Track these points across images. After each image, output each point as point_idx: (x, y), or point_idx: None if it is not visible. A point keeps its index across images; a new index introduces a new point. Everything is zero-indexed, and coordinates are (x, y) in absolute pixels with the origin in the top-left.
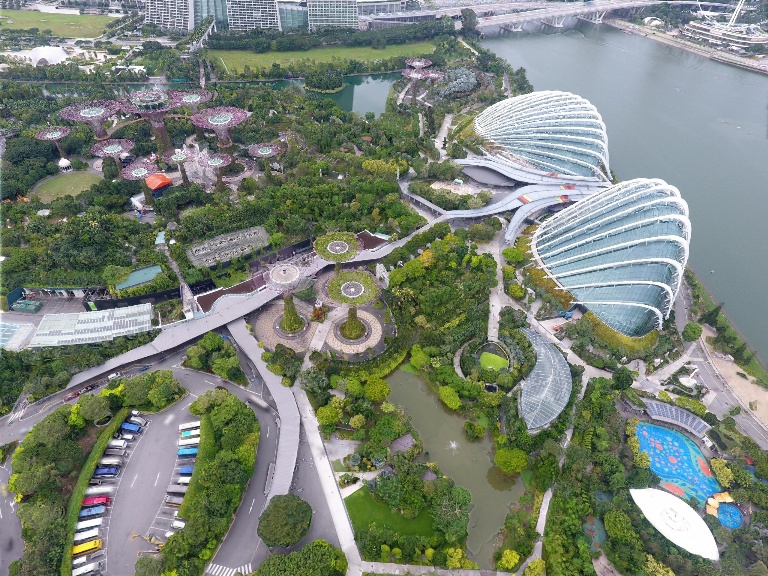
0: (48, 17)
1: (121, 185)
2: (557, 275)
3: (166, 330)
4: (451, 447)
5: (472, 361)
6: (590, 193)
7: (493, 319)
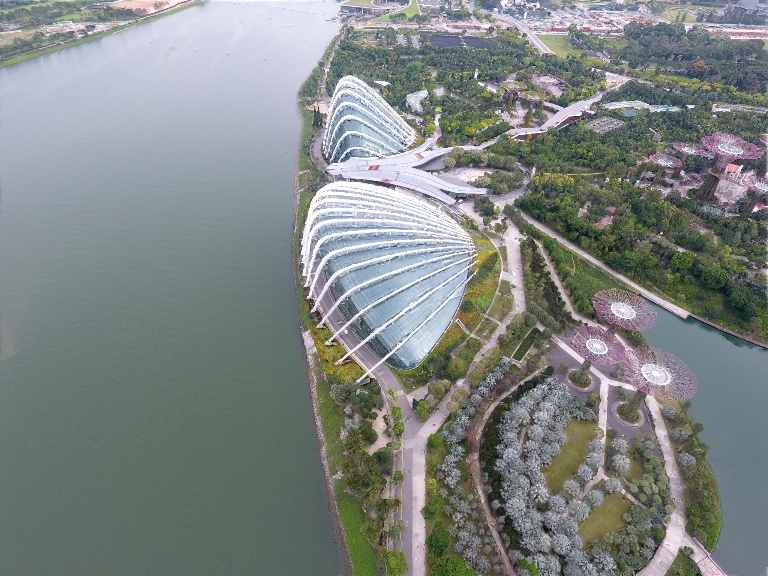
0: None
1: None
2: None
3: None
4: (452, 96)
5: (449, 100)
6: (360, 162)
7: None
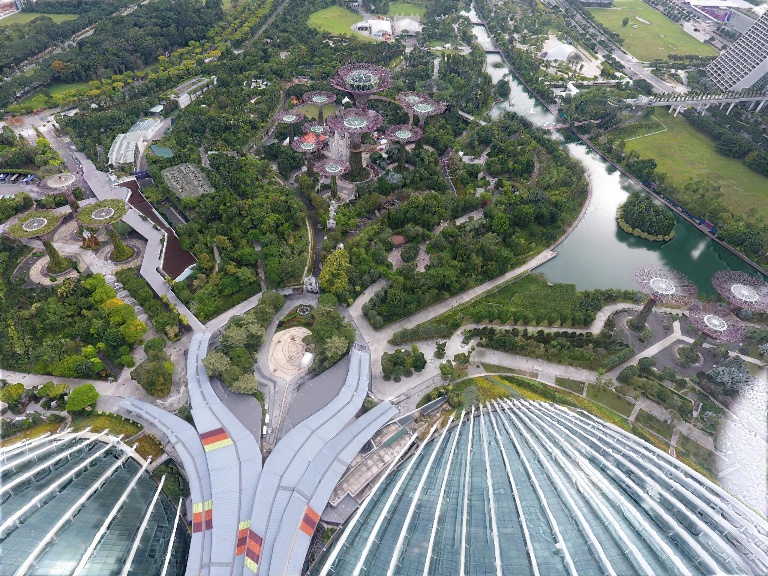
0: (673, 34)
1: (296, 123)
2: (6, 447)
3: (105, 174)
4: None
5: None
6: None
7: (4, 374)
